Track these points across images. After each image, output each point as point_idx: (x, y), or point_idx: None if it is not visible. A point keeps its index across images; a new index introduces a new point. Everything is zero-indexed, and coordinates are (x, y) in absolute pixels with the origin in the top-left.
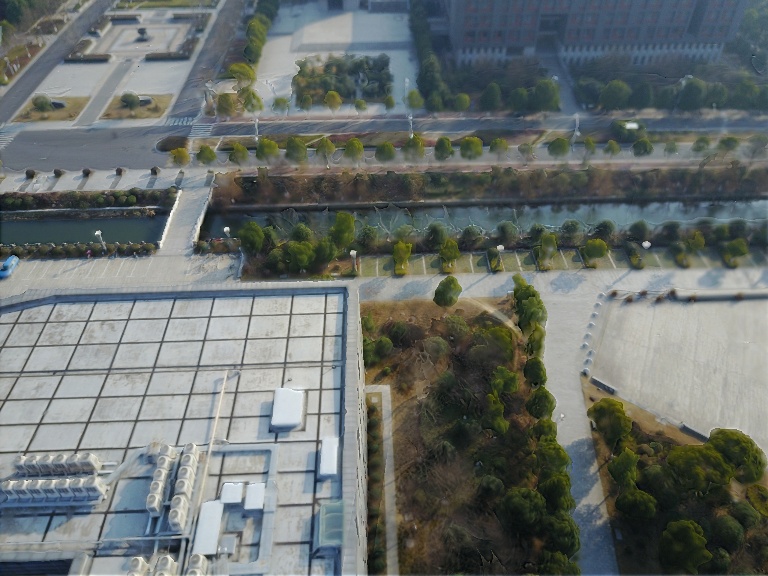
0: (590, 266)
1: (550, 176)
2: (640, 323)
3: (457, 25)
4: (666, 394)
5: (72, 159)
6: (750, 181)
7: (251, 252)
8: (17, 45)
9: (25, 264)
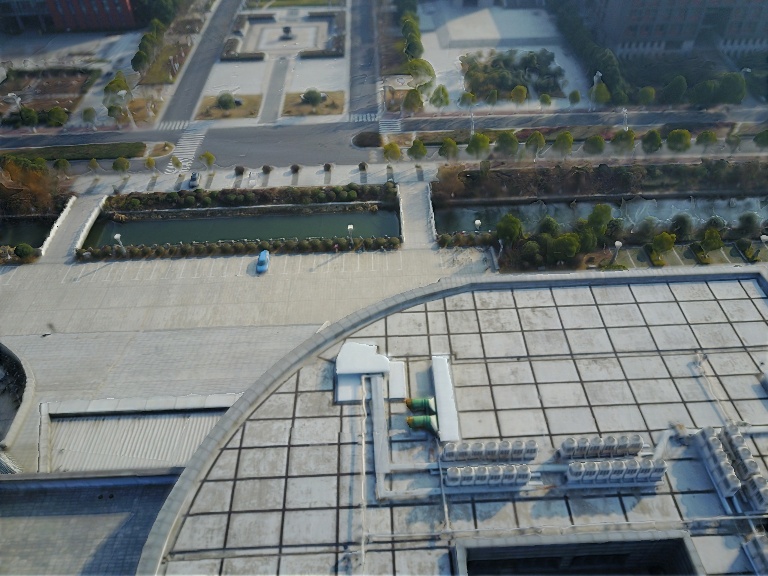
0: None
1: (762, 167)
2: None
3: (614, 20)
4: None
5: (272, 156)
6: None
7: (509, 244)
8: (166, 44)
9: (275, 259)
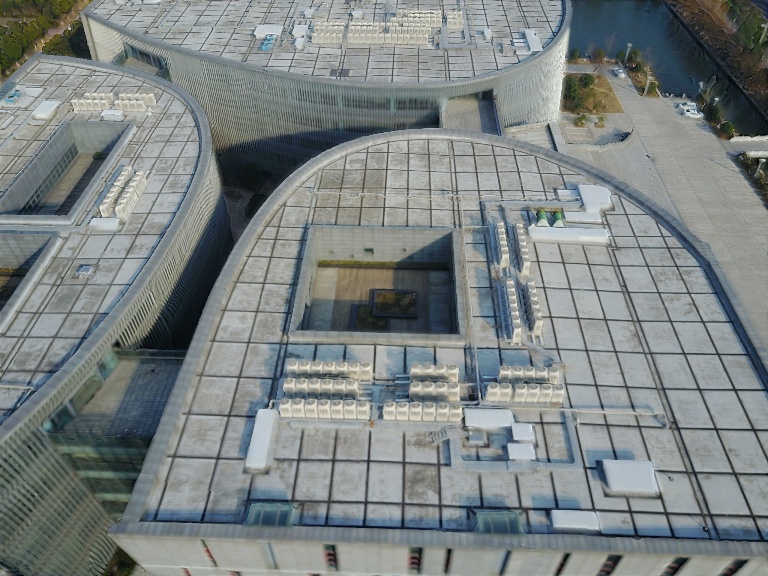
0: None
1: None
2: None
3: None
4: None
5: None
6: None
7: None
8: None
9: None
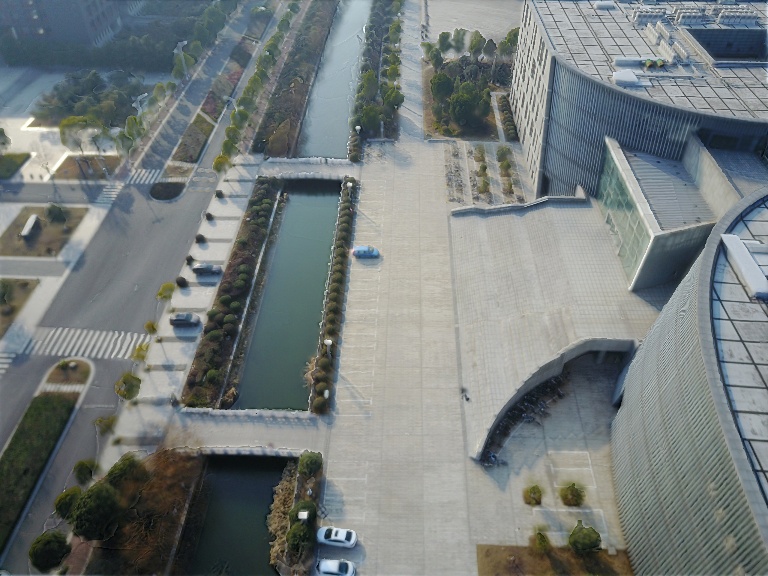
0: None
1: None
2: None
3: (64, 27)
4: None
5: (154, 261)
6: None
7: None
8: None
9: None
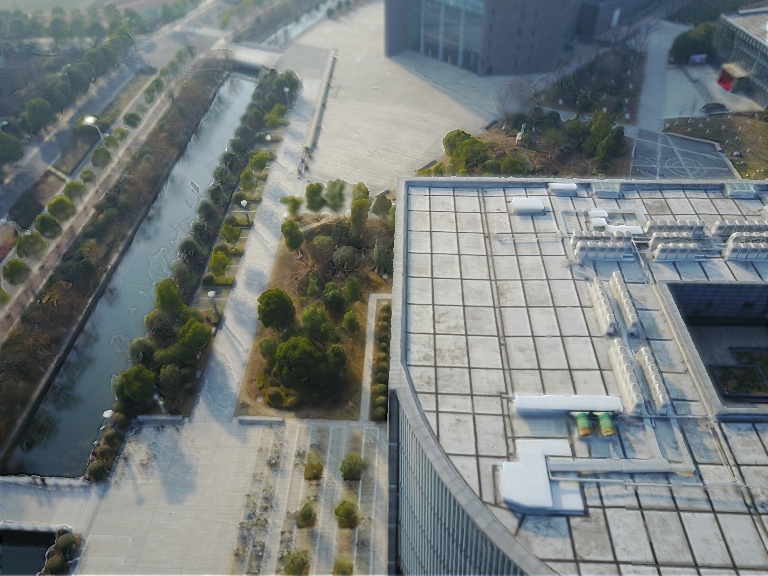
0: (265, 177)
1: None
2: (330, 169)
3: None
4: (393, 172)
5: None
6: (196, 96)
7: (161, 390)
8: None
9: None
